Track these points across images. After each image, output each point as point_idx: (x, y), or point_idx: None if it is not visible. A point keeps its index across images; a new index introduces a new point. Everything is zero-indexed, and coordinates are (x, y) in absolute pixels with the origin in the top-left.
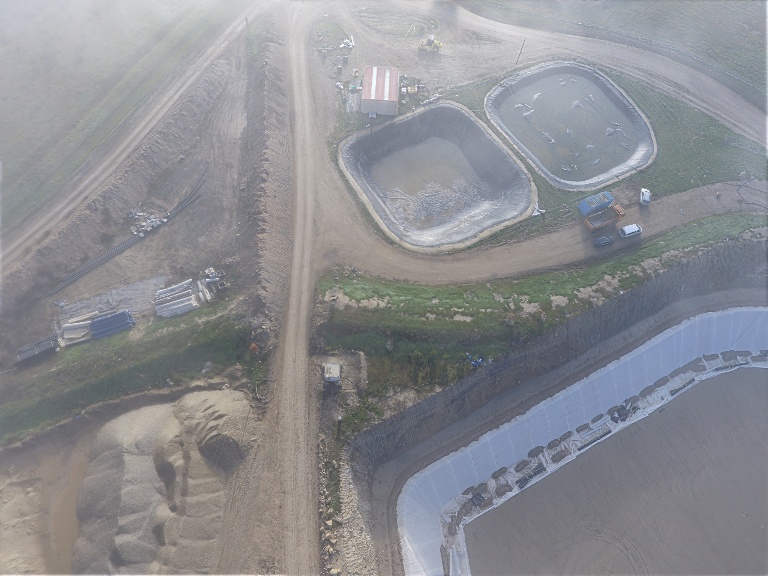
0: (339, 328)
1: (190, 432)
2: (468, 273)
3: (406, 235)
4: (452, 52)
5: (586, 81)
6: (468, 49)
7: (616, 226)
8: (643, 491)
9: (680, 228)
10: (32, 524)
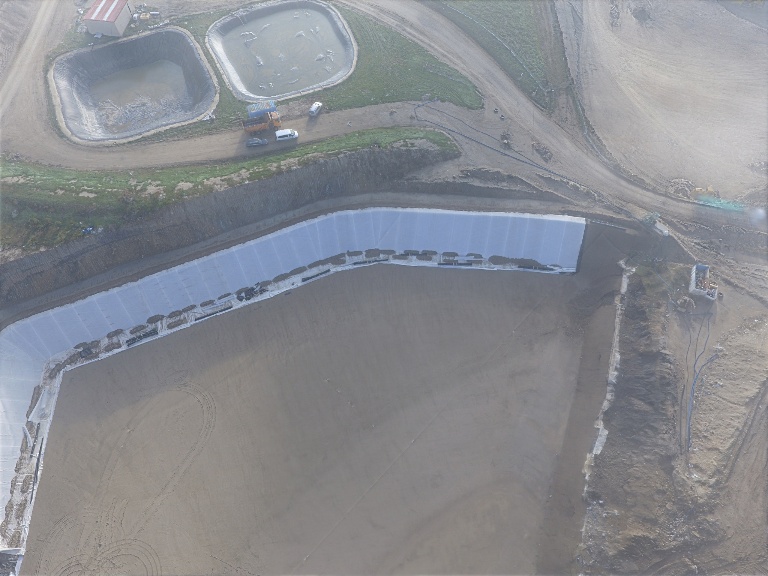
0: None
1: None
2: (118, 162)
3: (88, 134)
4: None
5: (319, 15)
6: None
7: None
8: (240, 356)
9: (340, 137)
10: None
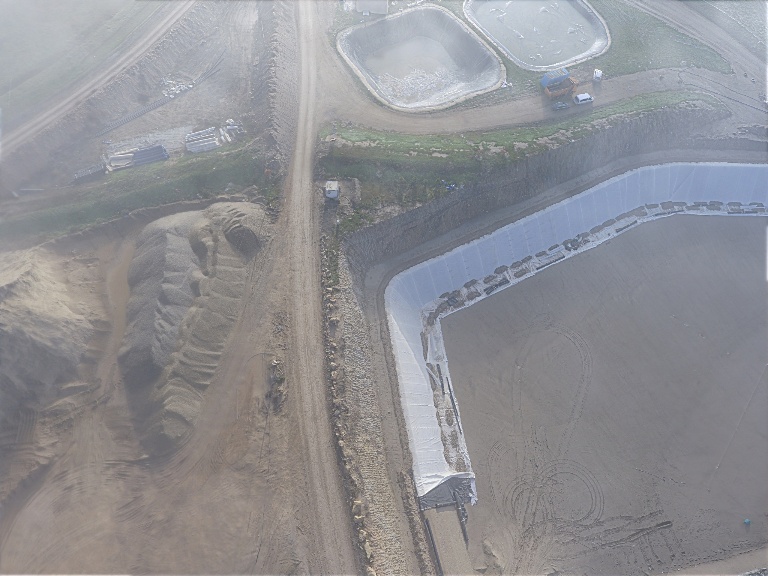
0: (337, 160)
1: (218, 224)
2: (445, 127)
3: (394, 103)
4: None
5: None
6: None
7: (572, 97)
8: (589, 299)
9: (627, 100)
10: (93, 286)
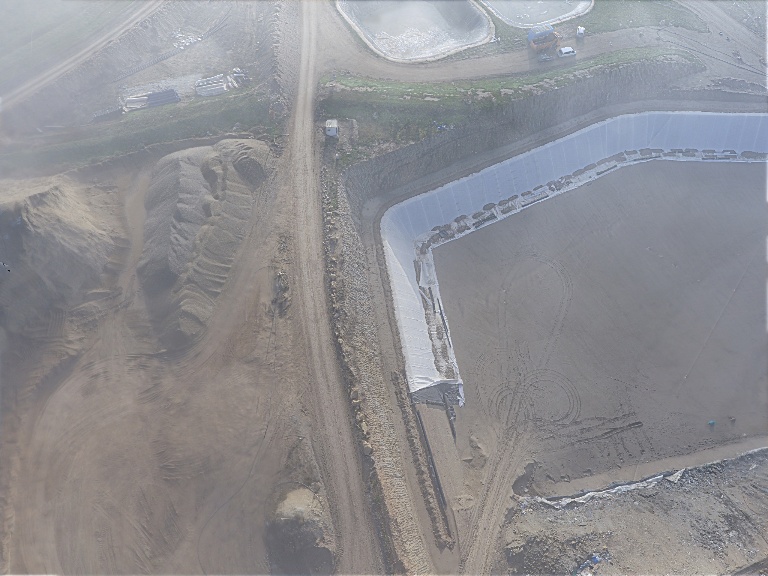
0: (337, 103)
1: (227, 155)
2: (437, 76)
3: None
4: None
5: None
6: None
7: (556, 51)
8: (571, 232)
9: (608, 54)
10: (113, 209)
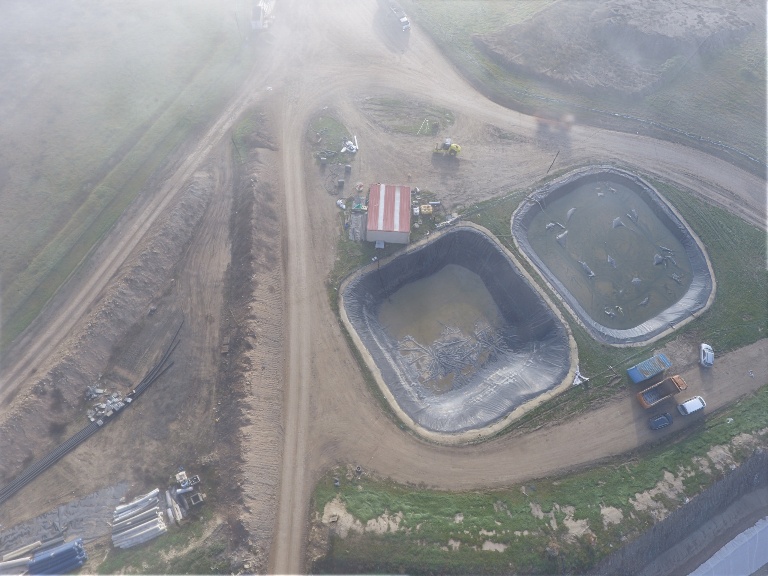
0: (340, 565)
1: None
2: (498, 472)
3: (421, 410)
4: (471, 156)
5: (627, 190)
6: (490, 151)
7: (674, 397)
8: None
9: (750, 397)
10: None
